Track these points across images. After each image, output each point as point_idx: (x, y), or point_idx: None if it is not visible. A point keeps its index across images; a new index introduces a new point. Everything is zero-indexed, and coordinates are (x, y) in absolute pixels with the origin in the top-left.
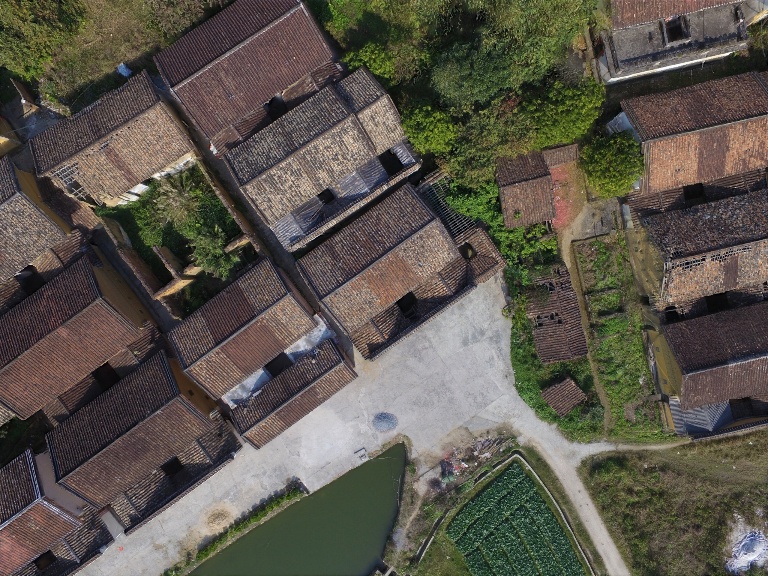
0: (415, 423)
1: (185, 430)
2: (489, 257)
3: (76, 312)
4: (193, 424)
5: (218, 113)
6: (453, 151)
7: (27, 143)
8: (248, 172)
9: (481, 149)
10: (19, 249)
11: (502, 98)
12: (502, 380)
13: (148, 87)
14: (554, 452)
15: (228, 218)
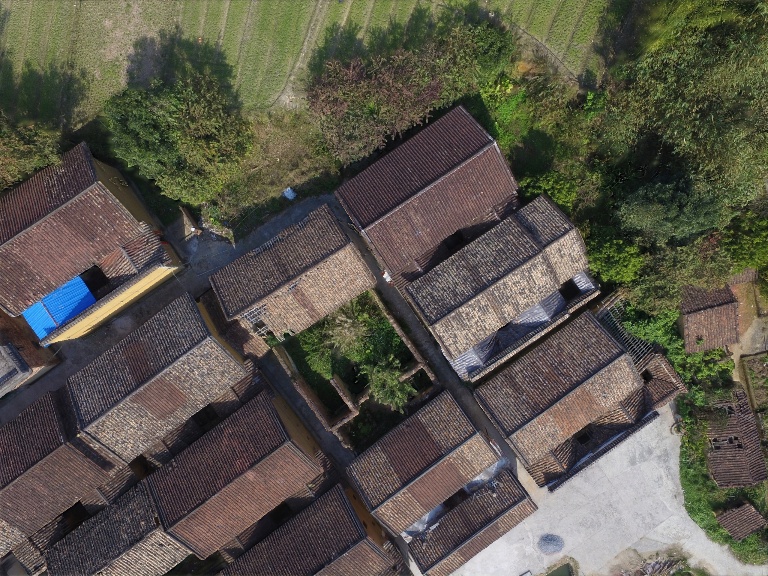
0: (581, 545)
1: (366, 569)
2: (667, 381)
3: (264, 455)
4: (374, 562)
5: (404, 249)
6: (636, 279)
7: (189, 266)
8: (435, 309)
9: (670, 280)
10: (203, 389)
11: (704, 236)
12: (671, 500)
13: (333, 224)
14: (726, 574)
15: (395, 341)
